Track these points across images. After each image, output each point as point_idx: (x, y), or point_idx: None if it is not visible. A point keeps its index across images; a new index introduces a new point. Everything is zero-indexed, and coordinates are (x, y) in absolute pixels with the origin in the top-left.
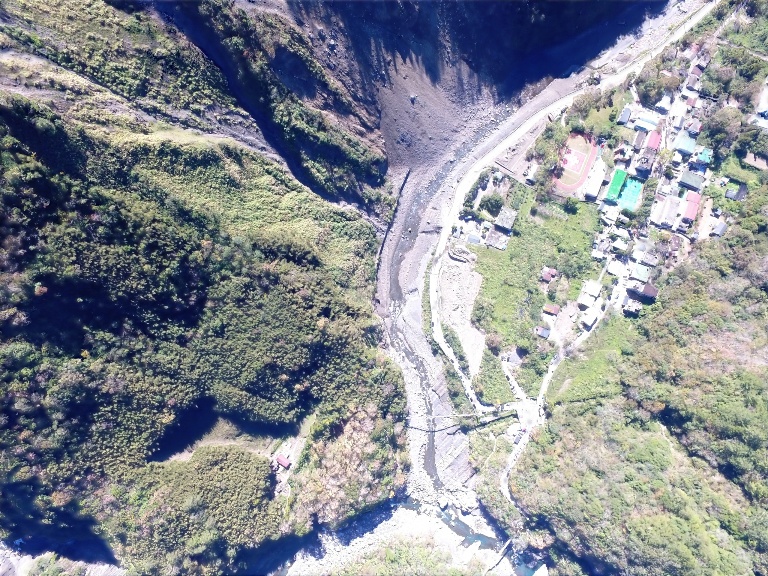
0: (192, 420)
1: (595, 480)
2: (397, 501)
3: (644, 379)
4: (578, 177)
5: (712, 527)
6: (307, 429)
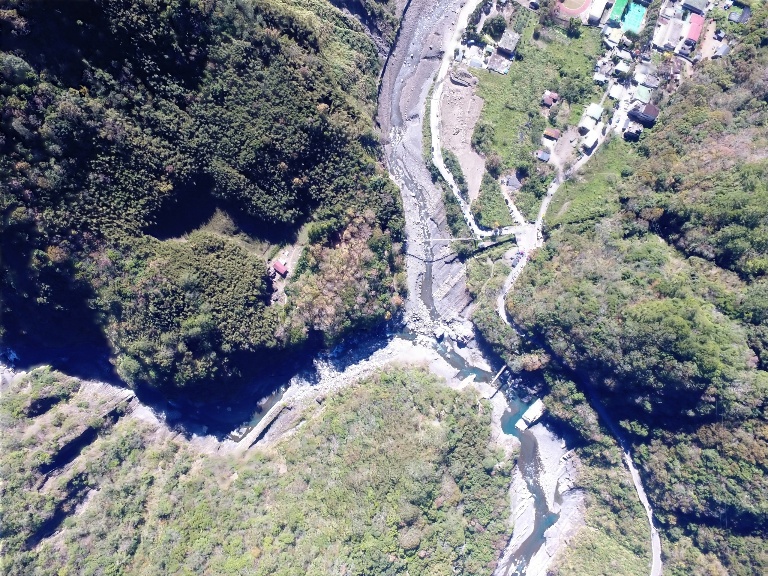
0: (190, 206)
1: (592, 286)
2: (393, 331)
3: (643, 192)
4: (582, 2)
5: (708, 307)
6: (305, 237)
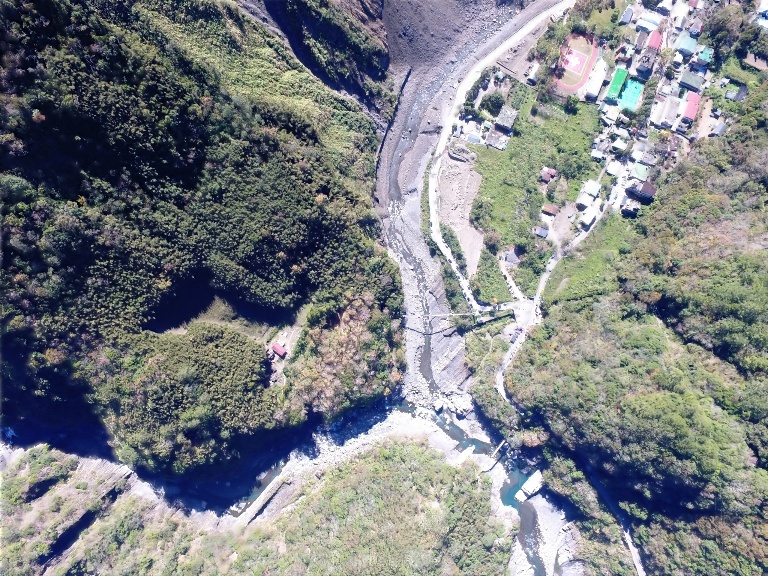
0: (188, 296)
1: (591, 369)
2: (392, 403)
3: (641, 273)
4: (579, 78)
5: (706, 402)
6: (303, 318)
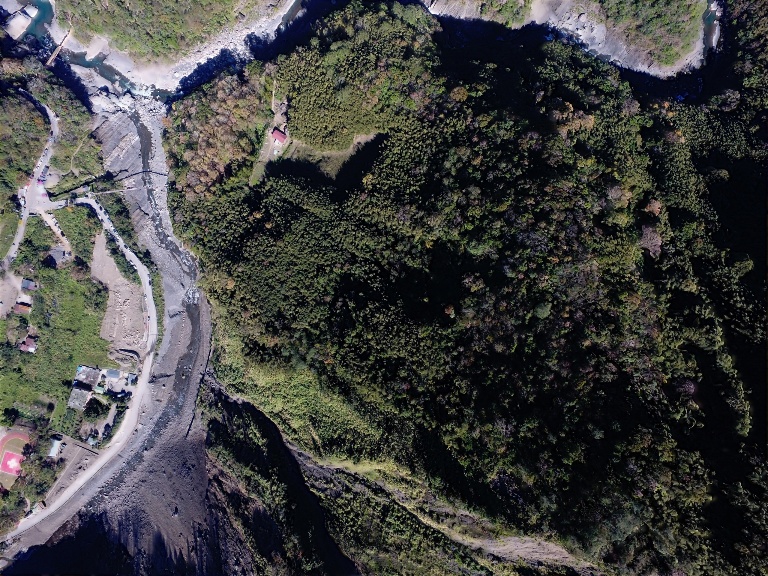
0: (359, 175)
1: None
2: (177, 98)
3: None
4: (7, 447)
5: None
6: (258, 170)
